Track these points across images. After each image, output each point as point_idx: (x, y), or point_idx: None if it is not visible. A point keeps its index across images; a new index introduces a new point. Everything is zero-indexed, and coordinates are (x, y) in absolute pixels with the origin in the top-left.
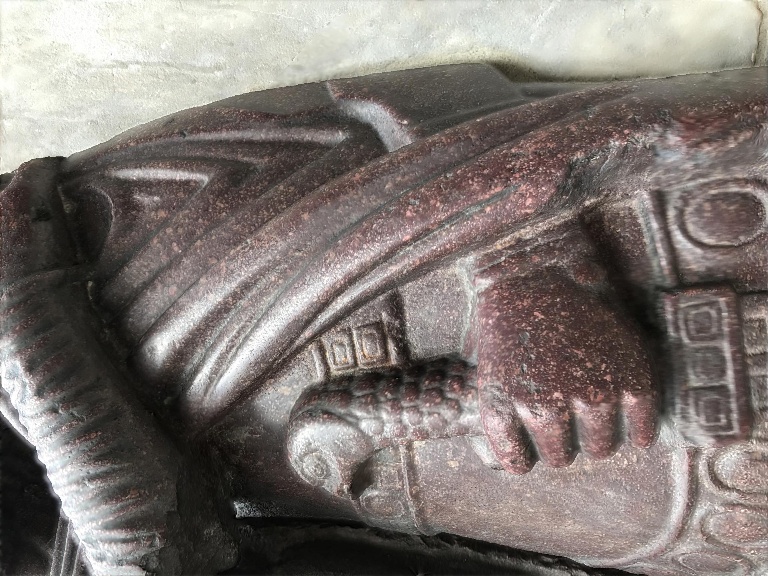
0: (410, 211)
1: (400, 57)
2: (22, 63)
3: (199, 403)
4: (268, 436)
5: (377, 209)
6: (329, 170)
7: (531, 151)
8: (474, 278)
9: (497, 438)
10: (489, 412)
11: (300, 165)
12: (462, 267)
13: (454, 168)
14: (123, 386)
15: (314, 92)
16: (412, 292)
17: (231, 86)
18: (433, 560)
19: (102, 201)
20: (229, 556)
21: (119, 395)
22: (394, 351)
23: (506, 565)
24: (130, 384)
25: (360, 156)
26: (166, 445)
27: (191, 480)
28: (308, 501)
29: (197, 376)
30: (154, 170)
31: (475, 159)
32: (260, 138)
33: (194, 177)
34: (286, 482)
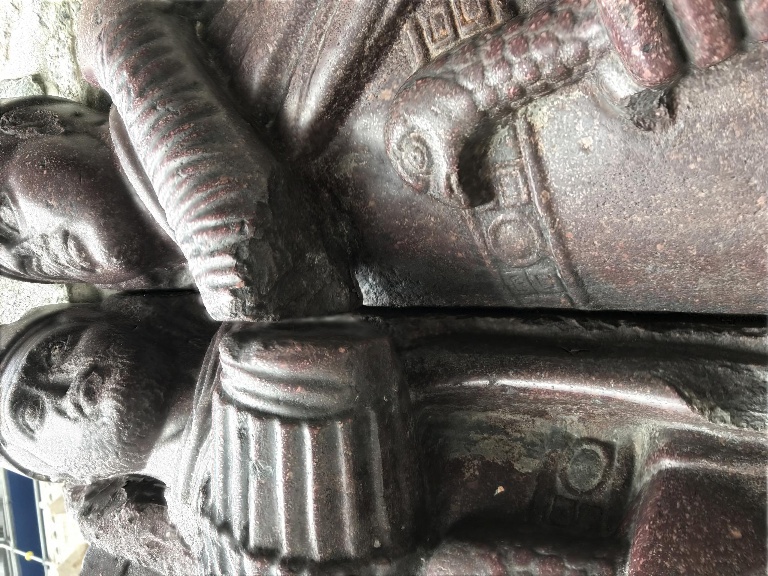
0: None
1: None
2: None
3: (295, 112)
4: (375, 162)
5: None
6: None
7: None
8: None
9: (615, 6)
10: None
11: None
12: None
13: None
14: (220, 95)
15: None
16: None
17: None
18: (592, 342)
19: None
20: (339, 297)
21: (214, 98)
22: (498, 6)
23: (691, 341)
24: (229, 98)
25: None
26: (260, 147)
27: (290, 194)
28: (431, 260)
29: (291, 80)
30: None
31: None
32: None
33: None
34: (402, 229)
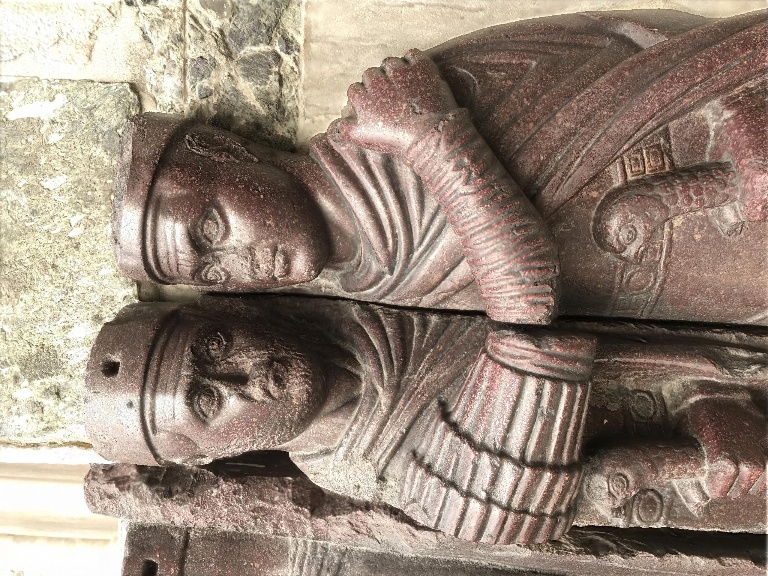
0: (700, 64)
1: (606, 5)
2: (331, 1)
3: (551, 198)
4: (575, 230)
5: (671, 68)
6: (613, 57)
7: (764, 32)
8: (722, 111)
9: (760, 189)
10: (758, 172)
11: (589, 56)
12: (708, 109)
13: (719, 42)
14: None
15: (577, 17)
16: (675, 127)
17: (490, 21)
18: (645, 336)
19: (463, 76)
20: (556, 309)
21: (517, 185)
22: (668, 162)
23: (692, 336)
24: None
25: (628, 50)
26: None
27: None
28: (579, 288)
29: (552, 179)
30: (498, 57)
31: (731, 37)
32: (558, 40)
33: (525, 61)
34: (574, 269)
